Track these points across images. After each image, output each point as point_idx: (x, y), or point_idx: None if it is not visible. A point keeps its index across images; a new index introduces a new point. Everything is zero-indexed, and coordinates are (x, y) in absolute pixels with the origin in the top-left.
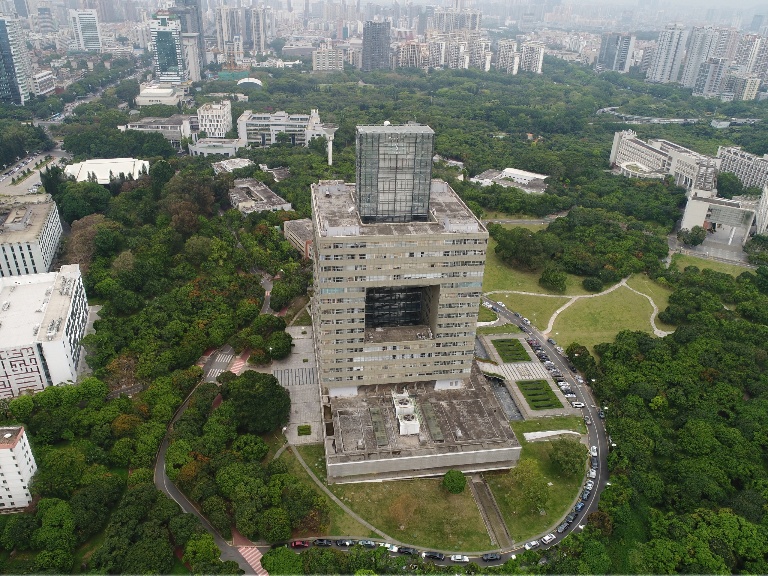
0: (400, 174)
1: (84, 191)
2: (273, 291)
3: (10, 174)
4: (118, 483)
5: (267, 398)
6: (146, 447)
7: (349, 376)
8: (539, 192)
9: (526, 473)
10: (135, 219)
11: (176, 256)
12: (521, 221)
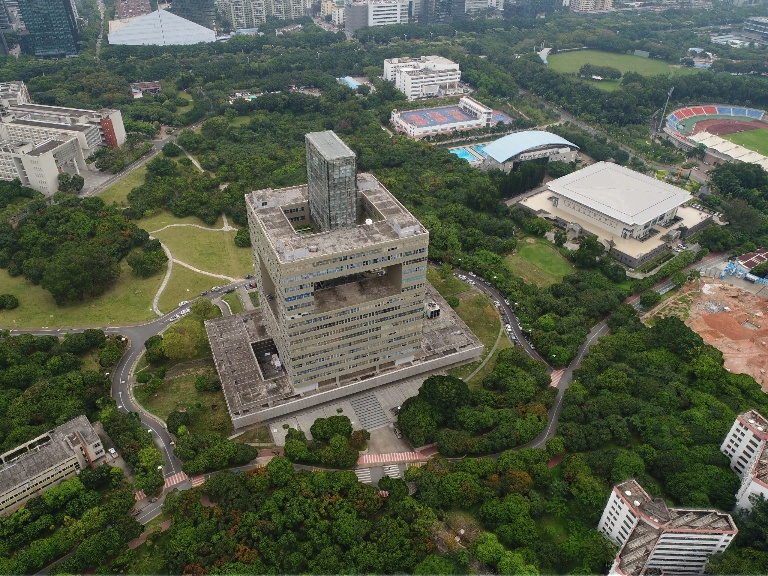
0: None
1: None
2: (228, 457)
3: None
4: None
5: None
6: (534, 450)
7: None
8: None
9: None
10: None
11: None
12: None
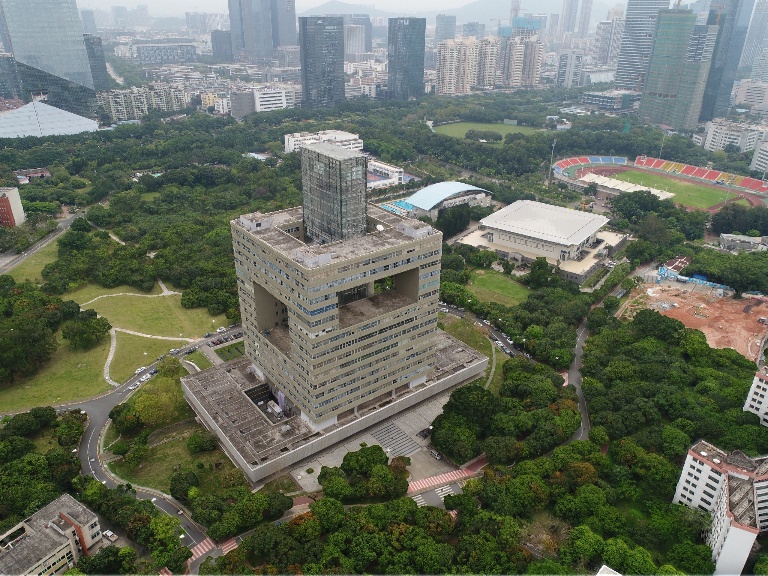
0: None
1: None
2: (262, 509)
3: None
4: None
5: None
6: (583, 441)
7: None
8: None
9: None
10: None
11: None
12: None
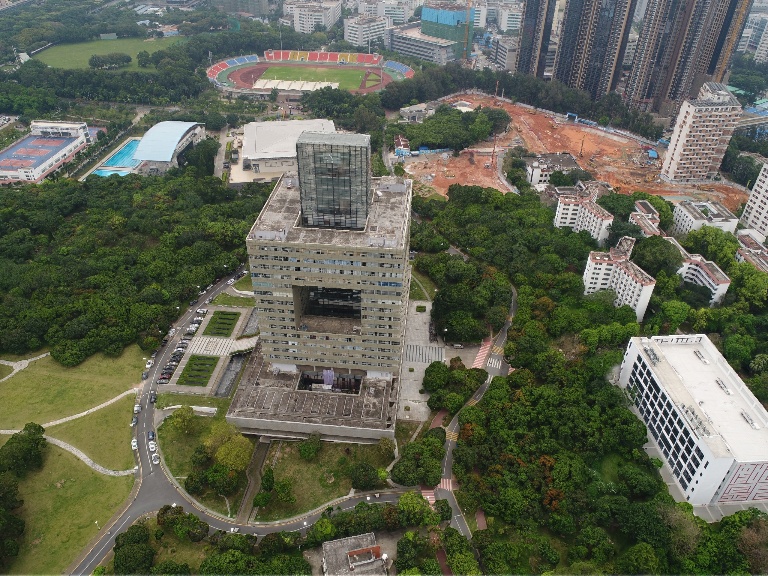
0: None
1: None
2: None
3: None
4: None
5: None
6: None
7: None
8: None
9: None
10: None
11: (613, 570)
12: None
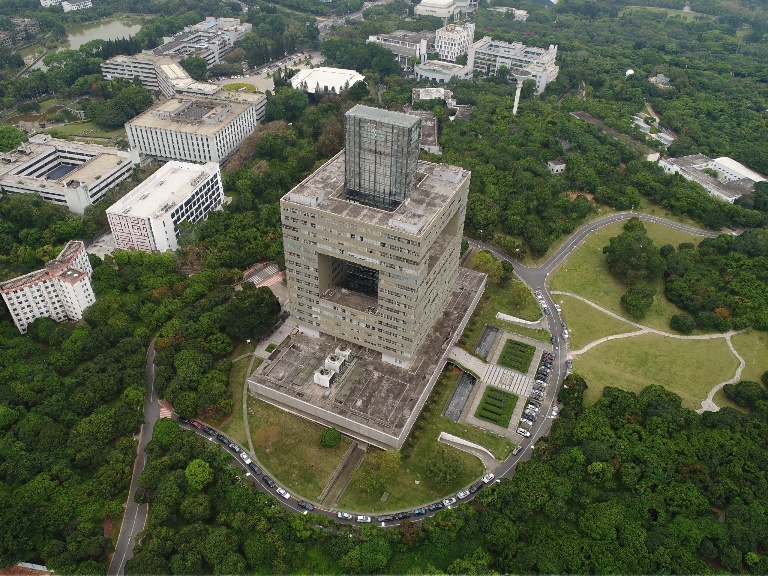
0: (379, 159)
1: (285, 98)
2: None
3: (272, 68)
4: (127, 331)
5: (245, 313)
6: (157, 315)
7: (310, 320)
8: (721, 197)
9: (383, 460)
10: (306, 131)
11: (304, 173)
12: (679, 225)
